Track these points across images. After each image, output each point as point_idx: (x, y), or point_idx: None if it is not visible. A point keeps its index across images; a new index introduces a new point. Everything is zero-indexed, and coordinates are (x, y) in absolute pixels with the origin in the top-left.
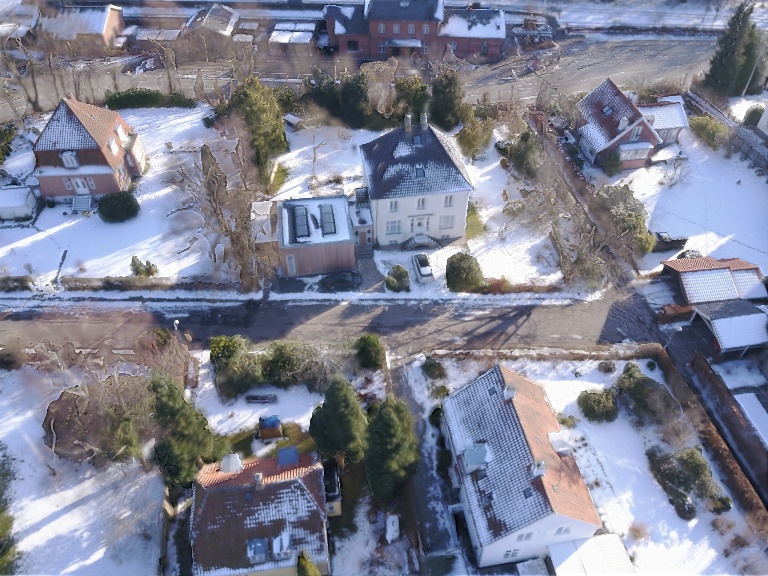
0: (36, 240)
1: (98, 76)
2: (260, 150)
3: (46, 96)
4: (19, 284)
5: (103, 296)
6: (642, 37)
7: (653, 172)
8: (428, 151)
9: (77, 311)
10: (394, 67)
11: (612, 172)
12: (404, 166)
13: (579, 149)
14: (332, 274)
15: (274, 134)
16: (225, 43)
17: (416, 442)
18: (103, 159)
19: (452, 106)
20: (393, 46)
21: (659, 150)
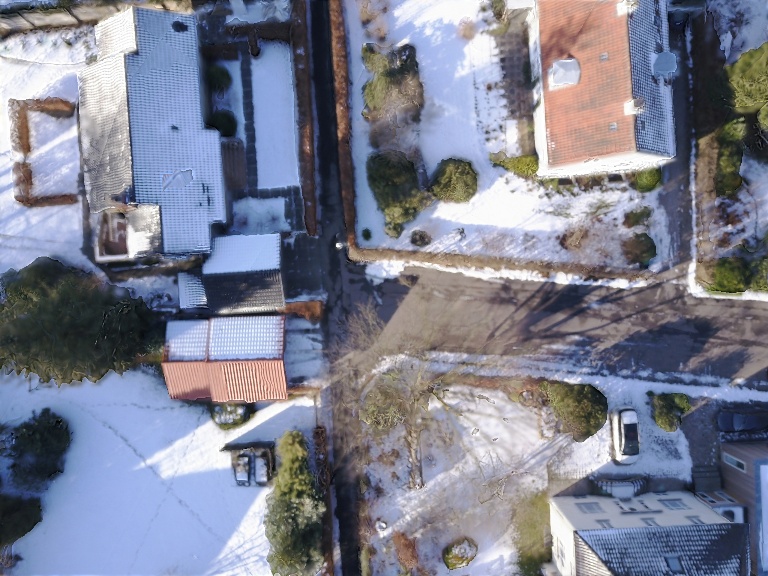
0: None
1: None
2: None
3: None
4: None
5: None
6: None
7: None
8: None
9: None
10: None
11: None
12: None
13: None
14: None
15: None
16: None
17: (675, 156)
18: None
19: None
20: None
21: None
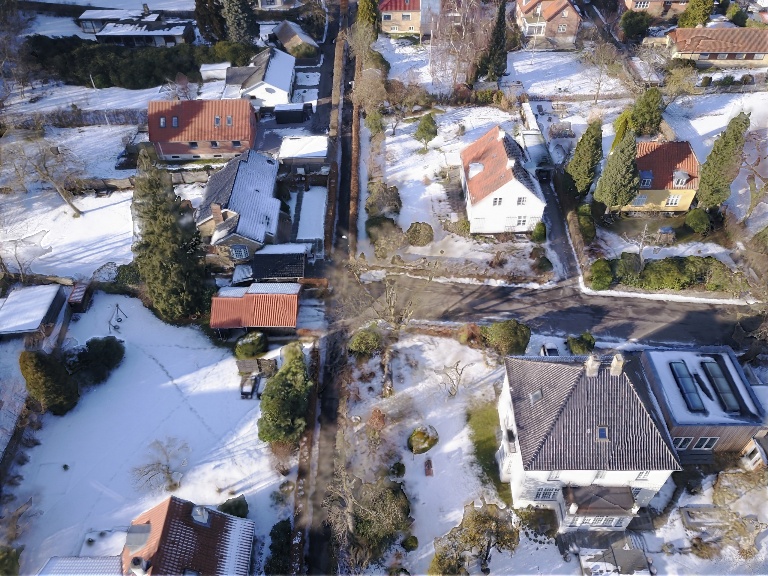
0: None
1: None
2: None
3: None
4: None
5: None
6: None
7: None
8: None
9: None
10: None
11: None
12: None
13: None
14: None
15: None
16: None
17: (556, 229)
18: None
19: None
20: None
21: None
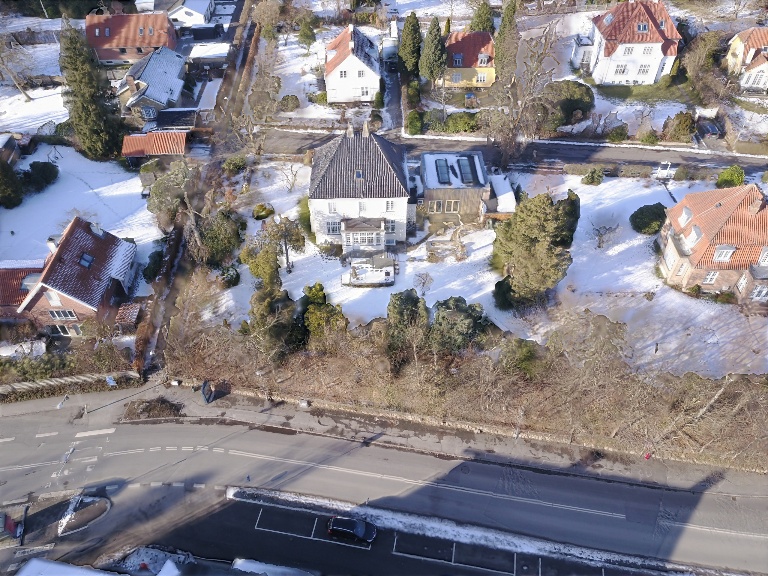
0: None
1: None
2: None
3: None
4: None
5: None
6: None
7: None
8: None
9: None
10: None
11: None
12: None
13: (132, 289)
14: None
15: None
16: None
17: (393, 100)
18: None
19: None
20: (298, 571)
21: None
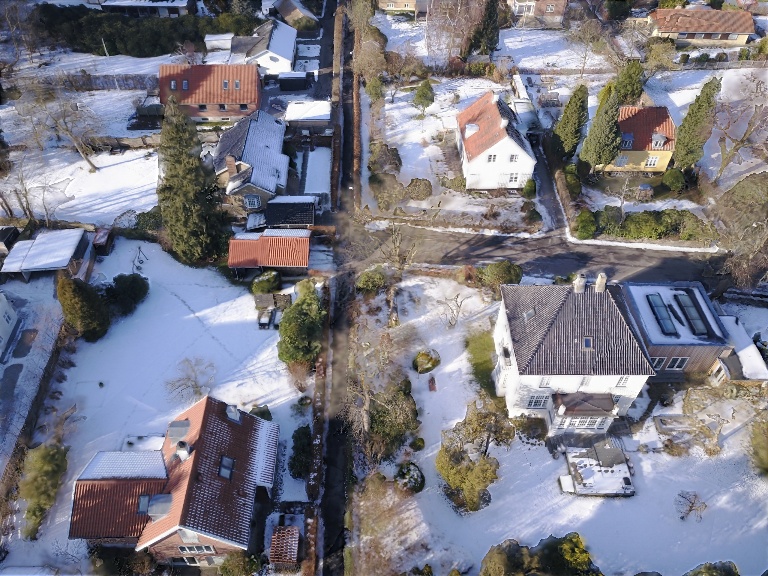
0: None
1: None
2: None
3: None
4: None
5: None
6: None
7: None
8: None
9: None
10: None
11: None
12: None
13: (275, 488)
14: None
15: None
16: None
17: (545, 187)
18: None
19: None
20: None
21: None
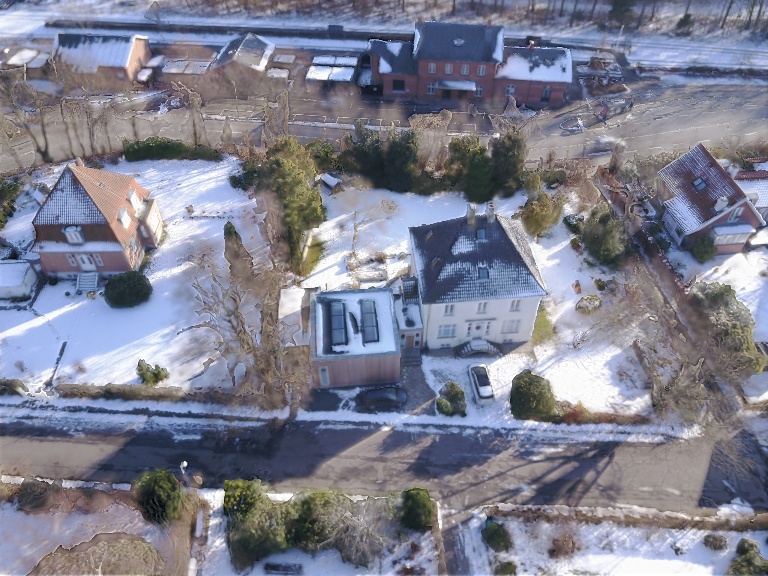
0: (32, 327)
1: (116, 122)
2: (292, 226)
3: (58, 144)
4: (8, 388)
5: (103, 406)
6: (726, 81)
7: (753, 259)
8: (494, 247)
9: (72, 426)
10: (448, 121)
11: (704, 259)
12: (464, 265)
13: (662, 225)
14: (372, 388)
15: (309, 207)
16: (258, 79)
17: None
18: (112, 235)
19: (514, 170)
20: (444, 89)
21: (758, 231)
